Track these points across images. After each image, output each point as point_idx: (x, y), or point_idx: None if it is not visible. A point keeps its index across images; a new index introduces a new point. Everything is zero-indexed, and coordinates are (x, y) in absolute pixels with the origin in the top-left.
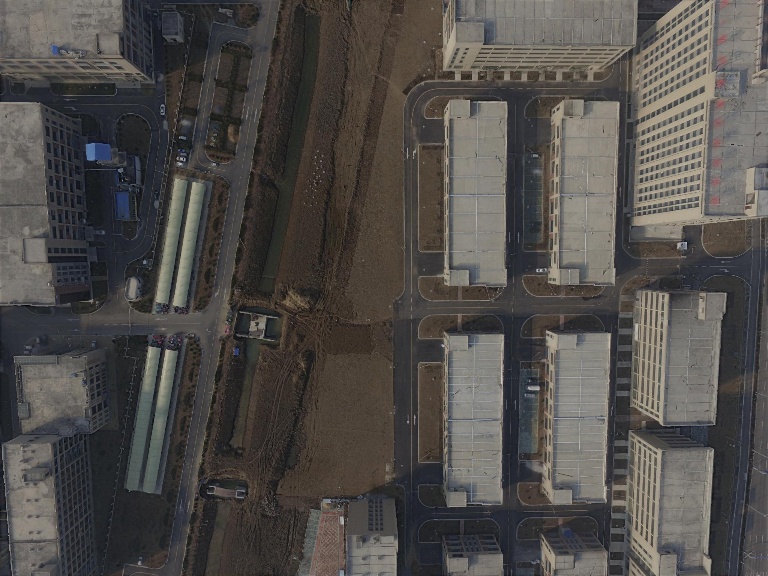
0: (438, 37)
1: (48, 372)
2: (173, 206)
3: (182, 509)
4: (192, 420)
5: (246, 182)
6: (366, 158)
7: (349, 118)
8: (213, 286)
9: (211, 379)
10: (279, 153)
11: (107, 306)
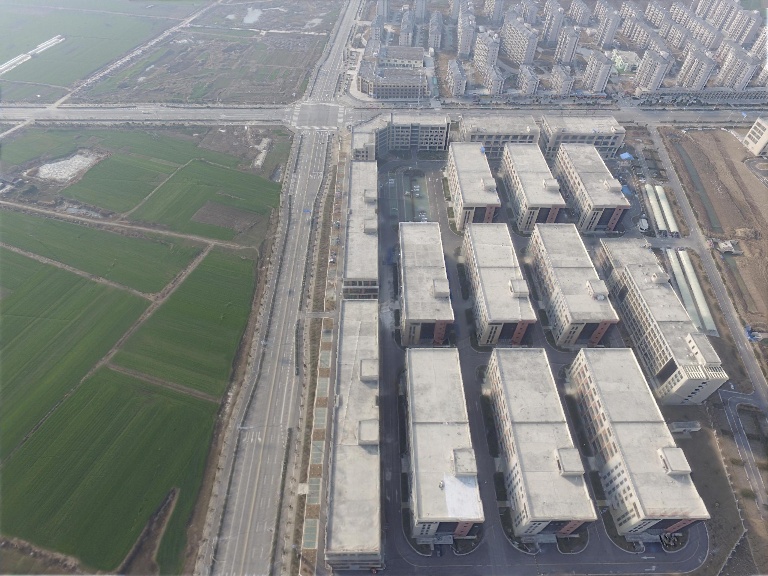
0: (744, 147)
1: (624, 245)
2: (650, 193)
3: (742, 348)
4: (715, 291)
5: (681, 189)
6: (739, 182)
7: (719, 170)
8: (688, 227)
9: (714, 270)
10: (691, 181)
11: (627, 235)
